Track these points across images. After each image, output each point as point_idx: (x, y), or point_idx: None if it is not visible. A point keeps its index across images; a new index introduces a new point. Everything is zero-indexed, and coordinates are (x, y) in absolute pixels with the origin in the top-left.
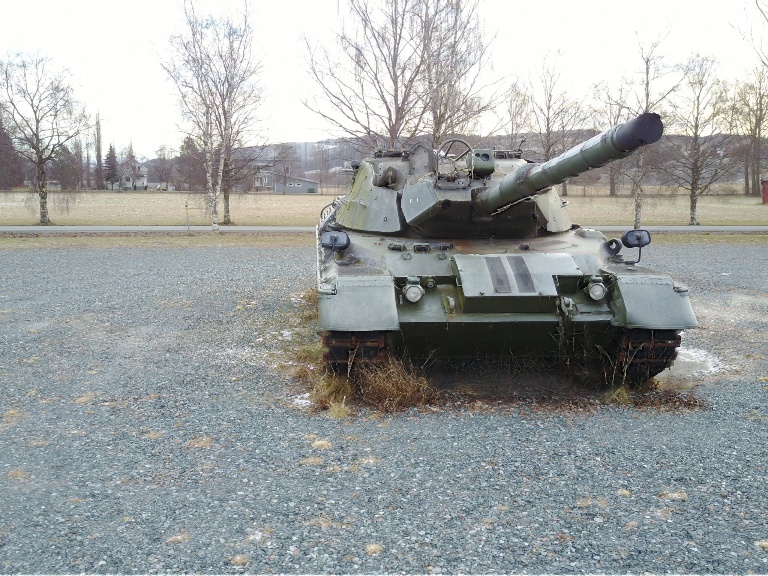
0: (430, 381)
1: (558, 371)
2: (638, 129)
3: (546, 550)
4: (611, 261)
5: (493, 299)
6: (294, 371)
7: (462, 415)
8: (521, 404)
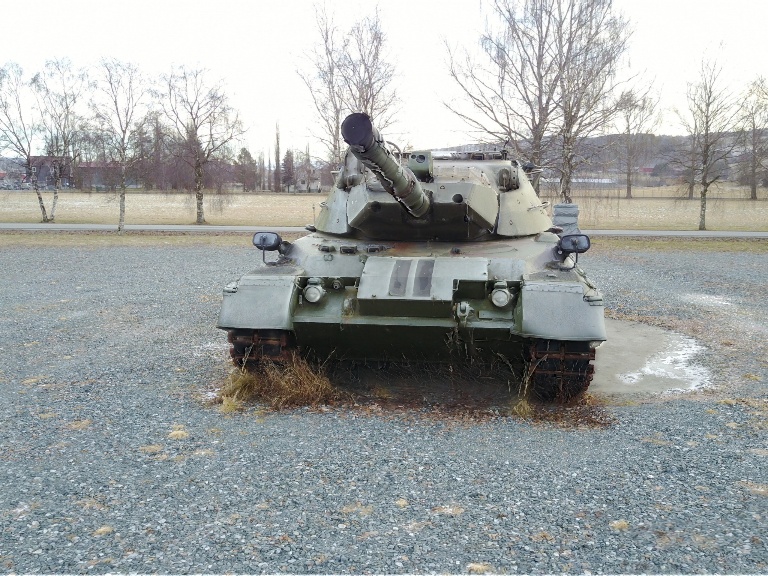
0: (360, 382)
1: (497, 380)
2: (343, 129)
3: (254, 549)
4: (549, 267)
5: (386, 302)
6: None
7: (345, 417)
8: (420, 410)
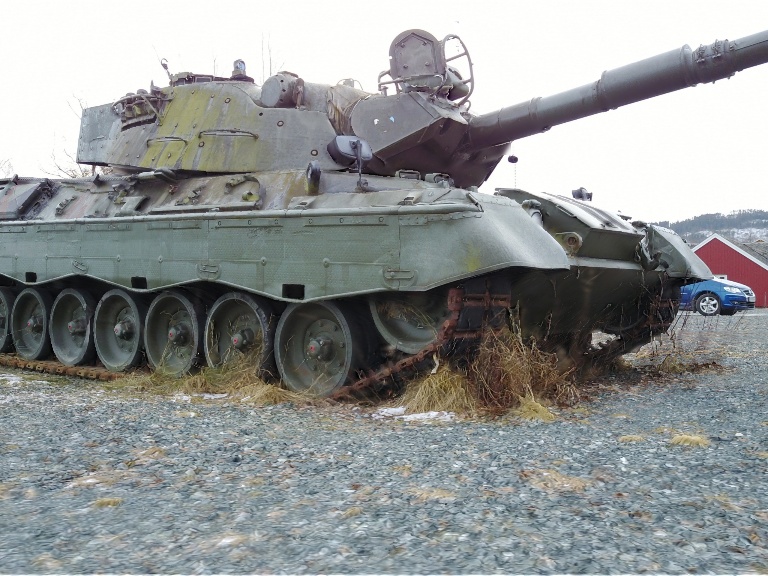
0: None
1: None
2: None
3: None
4: None
5: (608, 235)
6: (263, 393)
7: (631, 397)
8: None
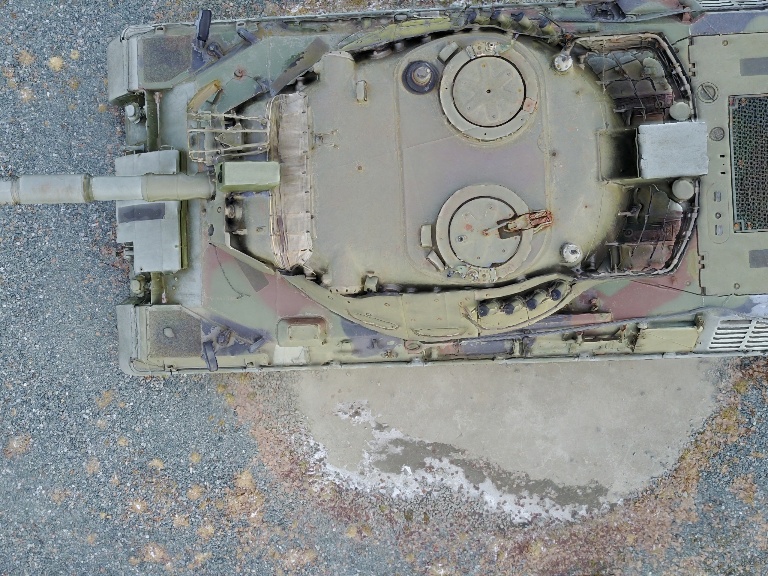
0: None
1: None
2: None
3: None
4: (224, 331)
5: None
6: None
7: None
8: None
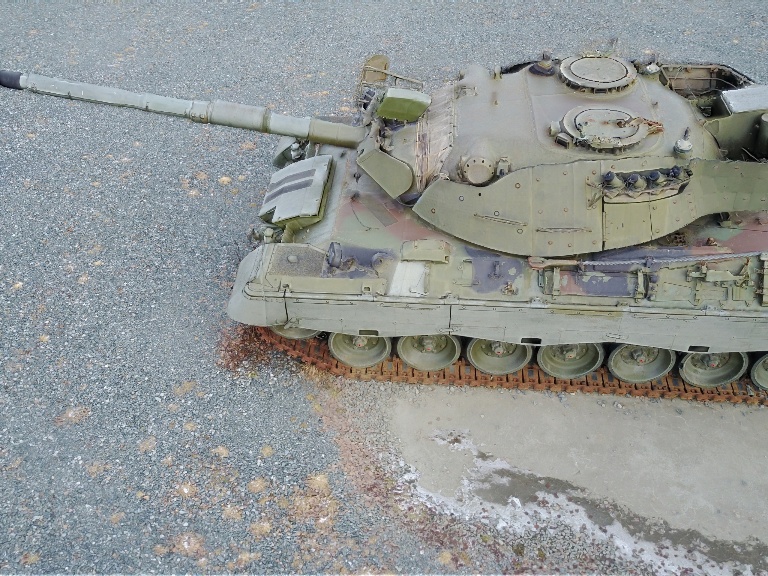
0: None
1: None
2: None
3: None
4: None
5: None
6: None
7: None
8: None
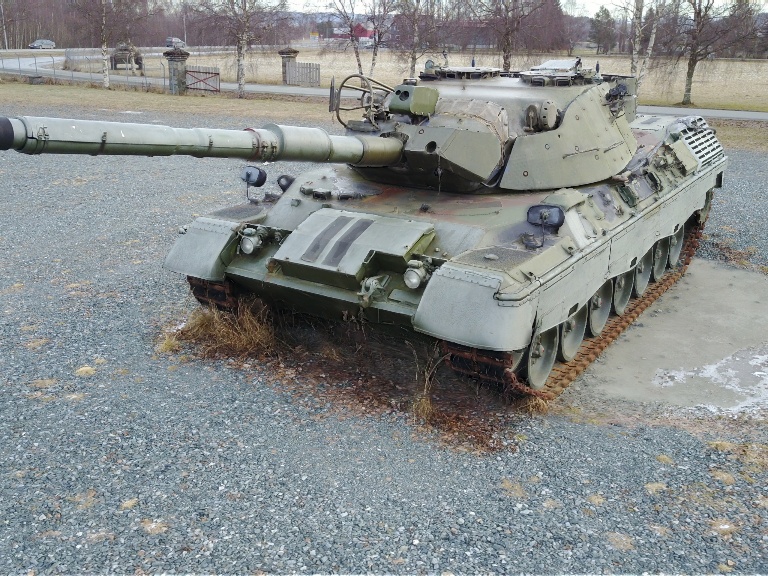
0: (334, 335)
1: None
2: None
3: None
4: None
5: (298, 266)
6: None
7: (250, 378)
8: (336, 384)
